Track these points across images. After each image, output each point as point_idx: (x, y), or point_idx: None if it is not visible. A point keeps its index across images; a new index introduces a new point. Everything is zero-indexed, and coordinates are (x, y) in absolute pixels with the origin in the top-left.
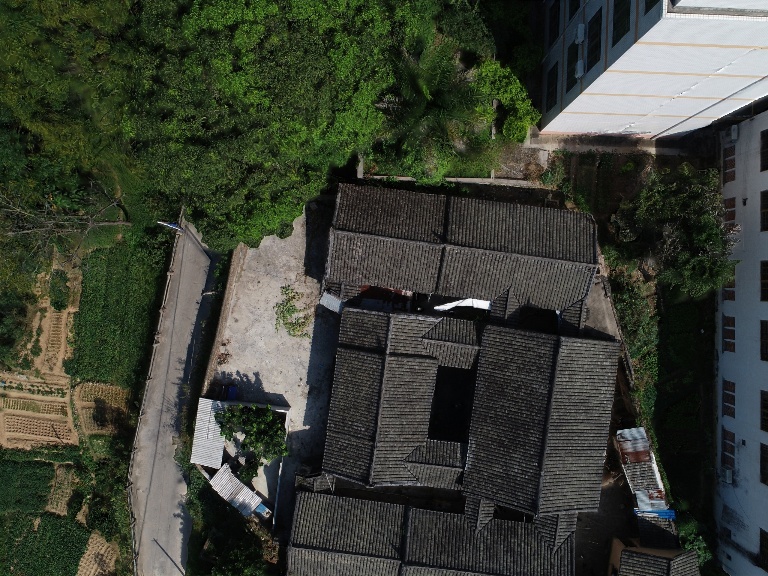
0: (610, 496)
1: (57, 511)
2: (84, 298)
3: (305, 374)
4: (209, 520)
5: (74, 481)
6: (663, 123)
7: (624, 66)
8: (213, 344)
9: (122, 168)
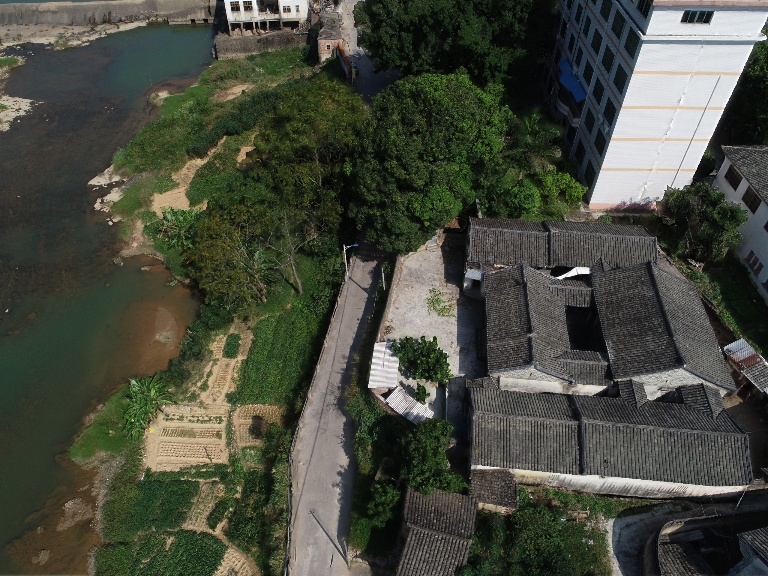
0: (746, 413)
1: (195, 527)
2: (254, 346)
3: (455, 340)
4: (377, 460)
5: (218, 495)
6: (664, 182)
7: (631, 100)
8: (384, 311)
9: (299, 262)
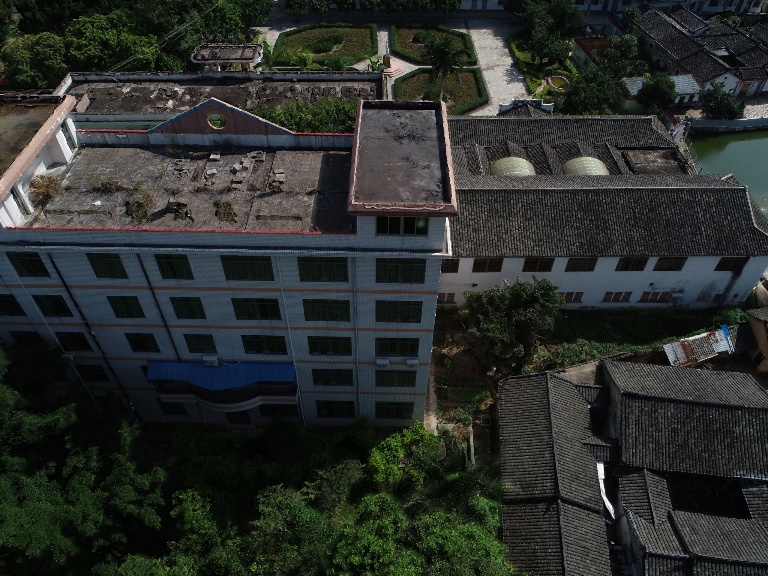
0: None
1: None
2: None
3: None
4: None
5: None
6: None
7: None
8: None
9: None
